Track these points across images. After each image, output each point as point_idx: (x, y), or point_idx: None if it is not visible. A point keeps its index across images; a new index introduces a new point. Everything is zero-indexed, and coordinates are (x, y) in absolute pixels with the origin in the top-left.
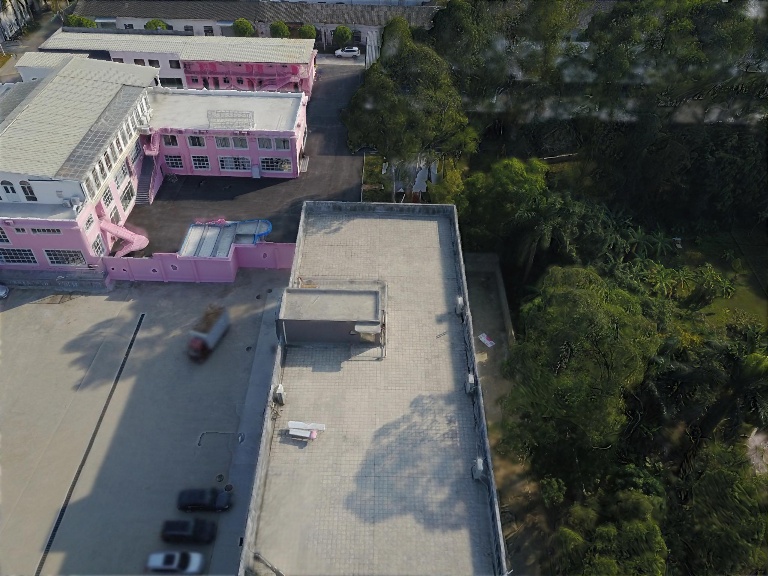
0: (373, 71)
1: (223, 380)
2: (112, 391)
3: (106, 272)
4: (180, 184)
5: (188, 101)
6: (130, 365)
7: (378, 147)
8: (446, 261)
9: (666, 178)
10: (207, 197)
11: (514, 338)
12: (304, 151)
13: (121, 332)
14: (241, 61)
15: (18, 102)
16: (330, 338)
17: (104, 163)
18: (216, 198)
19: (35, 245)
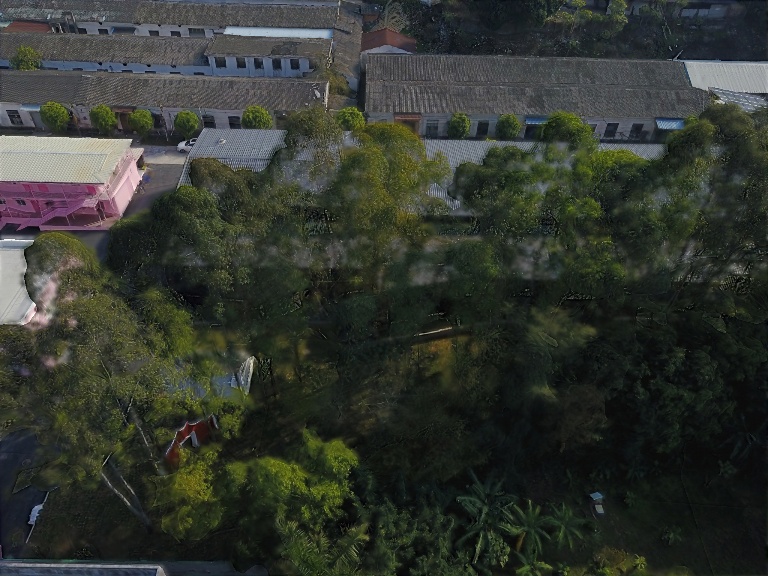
0: None
1: None
2: None
3: None
4: None
5: None
6: None
7: None
8: None
9: (568, 435)
10: None
11: None
12: None
13: None
14: (10, 180)
15: None
16: None
17: None
18: None
19: None
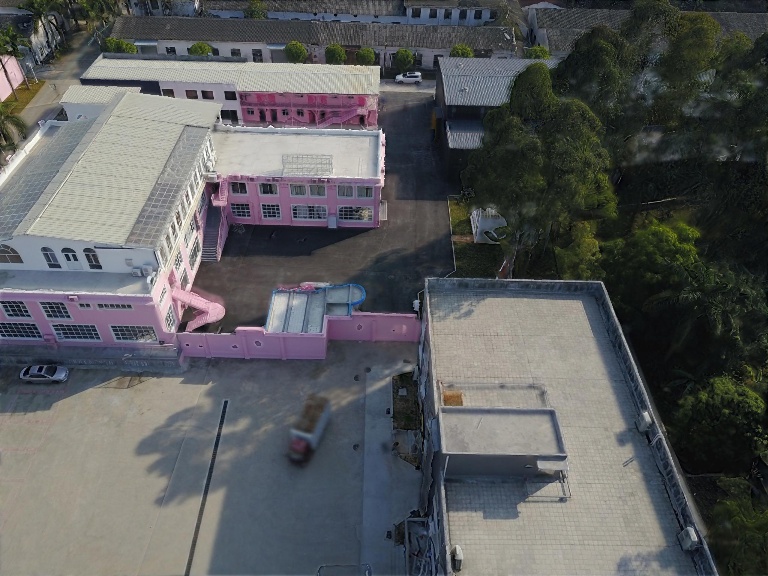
0: (511, 127)
1: (332, 489)
2: (203, 505)
3: (180, 349)
4: (248, 236)
5: (253, 141)
6: (220, 469)
7: (499, 208)
8: (606, 356)
9: None
10: (281, 252)
11: (666, 434)
12: None
13: (204, 425)
14: (304, 92)
15: (70, 148)
16: (498, 470)
17: (175, 222)
18: (291, 253)
19: (100, 320)
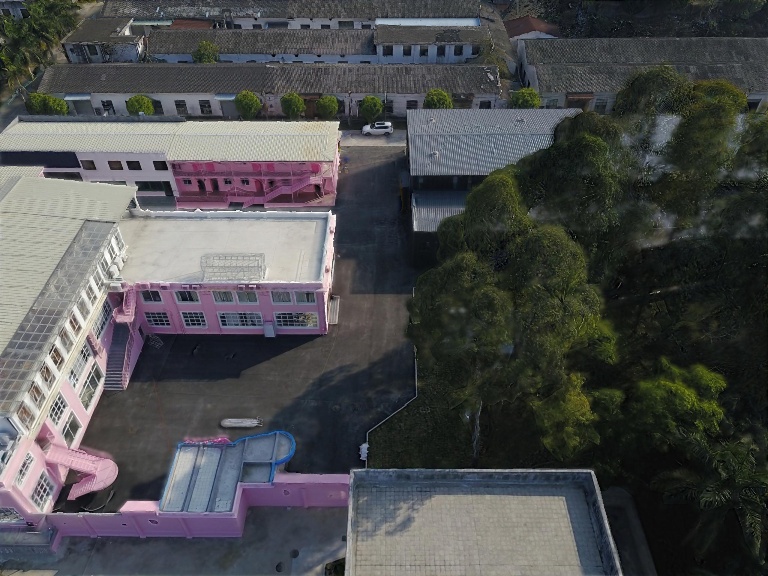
0: (460, 269)
1: None
2: None
3: (54, 529)
4: (166, 351)
5: (176, 230)
6: None
7: None
8: None
9: None
10: (203, 373)
11: None
12: (332, 288)
13: None
14: (246, 160)
15: None
16: None
17: (50, 363)
18: (215, 375)
19: None
